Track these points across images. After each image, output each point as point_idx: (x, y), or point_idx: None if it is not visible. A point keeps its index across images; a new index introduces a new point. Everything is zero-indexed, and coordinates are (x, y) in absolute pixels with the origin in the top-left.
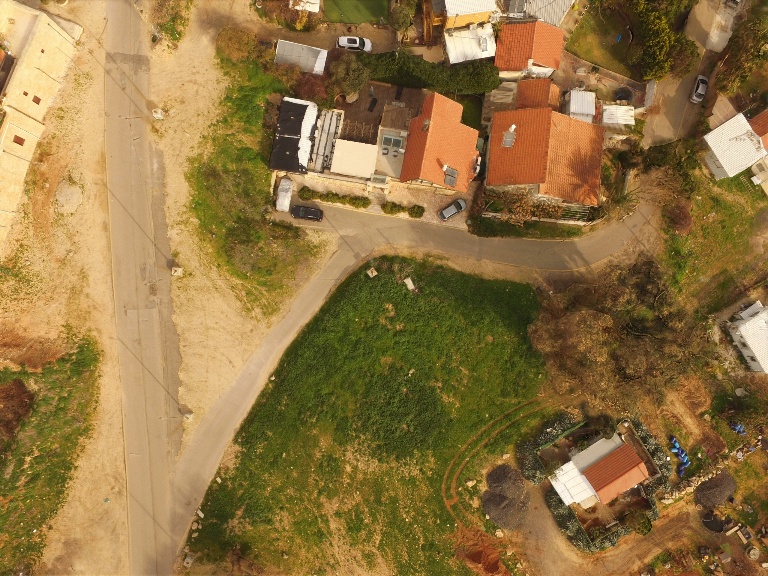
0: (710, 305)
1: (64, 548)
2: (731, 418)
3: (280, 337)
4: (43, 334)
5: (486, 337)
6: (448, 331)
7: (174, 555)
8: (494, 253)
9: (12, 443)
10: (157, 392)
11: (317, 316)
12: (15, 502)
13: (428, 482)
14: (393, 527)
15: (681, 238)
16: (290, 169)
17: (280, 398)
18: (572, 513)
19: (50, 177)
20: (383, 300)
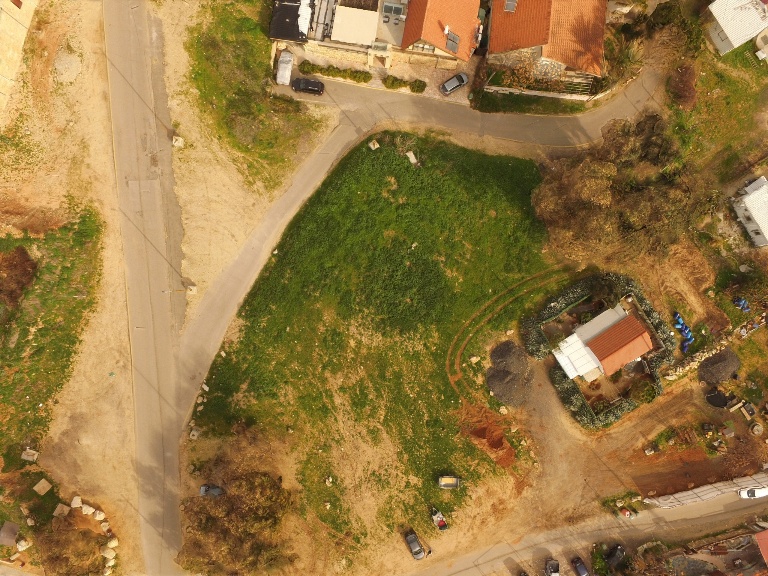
0: (714, 182)
1: (70, 422)
2: (735, 293)
3: (282, 211)
4: (45, 204)
5: (489, 212)
6: (451, 205)
7: (180, 429)
8: (496, 129)
9: (16, 312)
10: (160, 265)
11: (319, 190)
12: (20, 374)
13: (432, 357)
14: (397, 403)
15: (685, 113)
16: (290, 37)
17: (283, 271)
18: (576, 388)
19: (48, 45)
20: (385, 173)
